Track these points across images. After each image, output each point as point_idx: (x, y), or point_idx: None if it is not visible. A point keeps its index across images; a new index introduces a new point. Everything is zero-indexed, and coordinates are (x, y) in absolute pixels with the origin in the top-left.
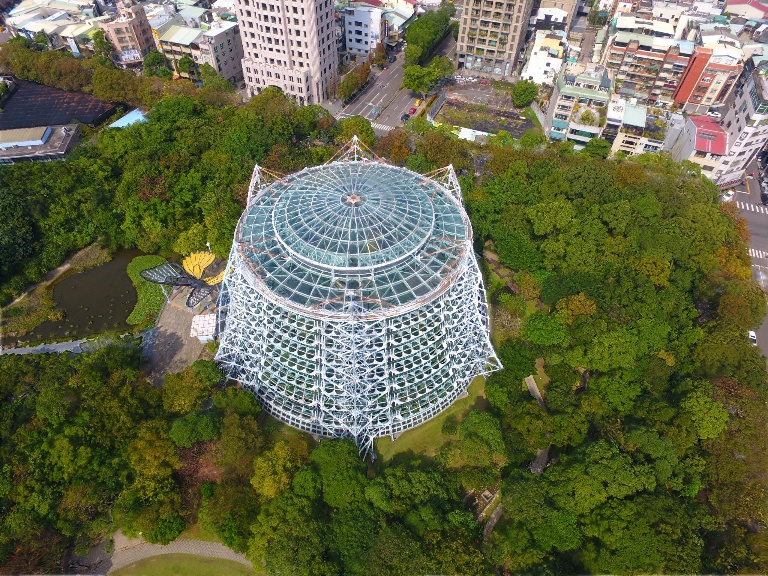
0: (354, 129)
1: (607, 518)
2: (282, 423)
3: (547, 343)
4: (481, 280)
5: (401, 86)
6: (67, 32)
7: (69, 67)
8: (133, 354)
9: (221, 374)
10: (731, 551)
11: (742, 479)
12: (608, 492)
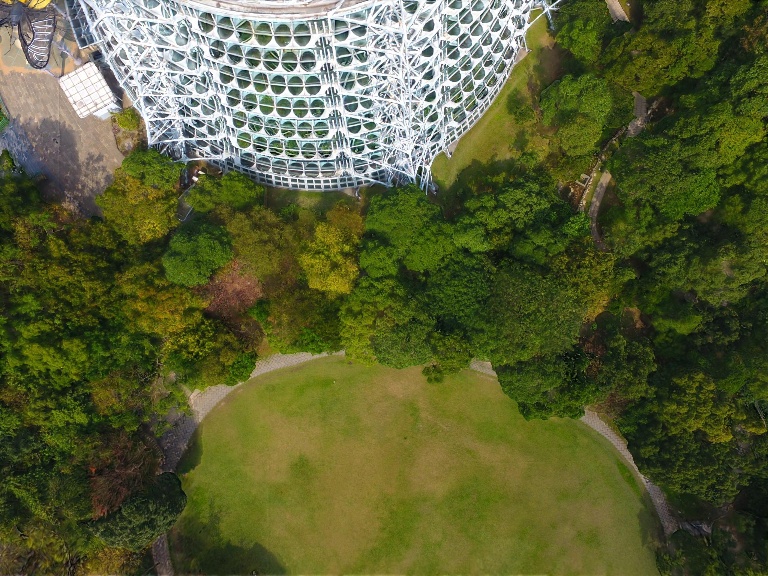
0: None
1: (763, 162)
2: (295, 191)
3: None
4: None
5: None
6: None
7: None
8: (18, 187)
9: (177, 164)
10: None
11: None
12: (767, 129)
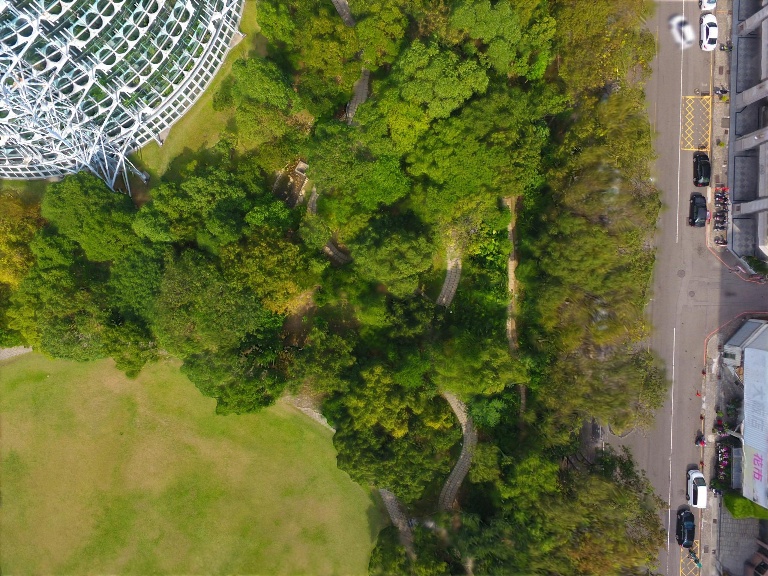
0: None
1: (431, 149)
2: None
3: None
4: None
5: None
6: None
7: None
8: None
9: None
10: (576, 133)
11: (601, 29)
12: (429, 115)
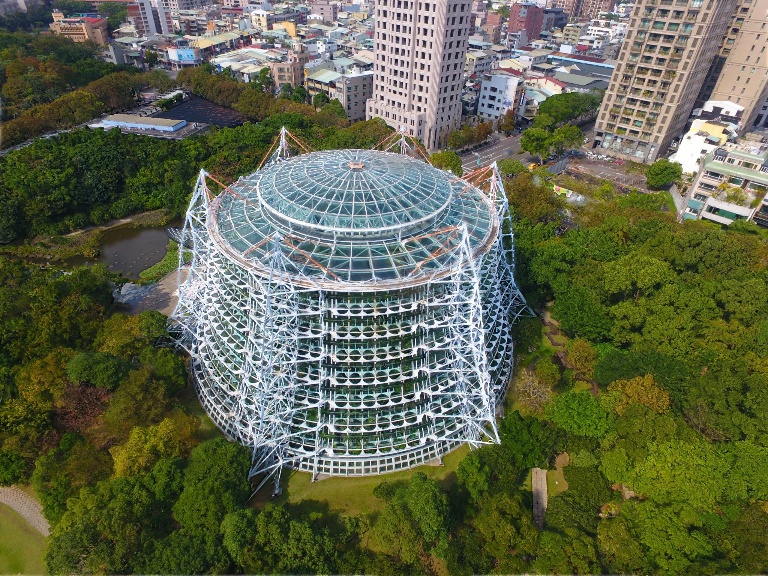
0: (440, 161)
1: None
2: (204, 411)
3: (577, 431)
4: (477, 290)
5: (521, 151)
6: (246, 70)
7: (228, 86)
8: (104, 287)
9: (164, 330)
10: None
11: None
12: None
